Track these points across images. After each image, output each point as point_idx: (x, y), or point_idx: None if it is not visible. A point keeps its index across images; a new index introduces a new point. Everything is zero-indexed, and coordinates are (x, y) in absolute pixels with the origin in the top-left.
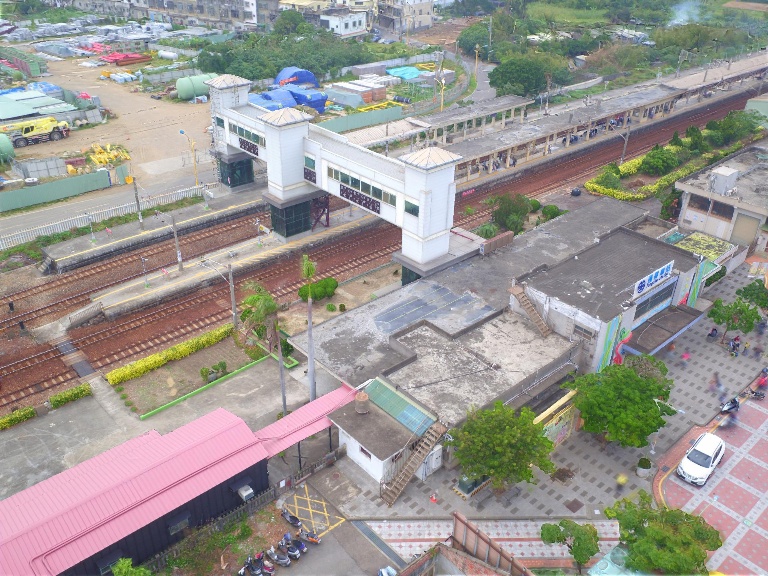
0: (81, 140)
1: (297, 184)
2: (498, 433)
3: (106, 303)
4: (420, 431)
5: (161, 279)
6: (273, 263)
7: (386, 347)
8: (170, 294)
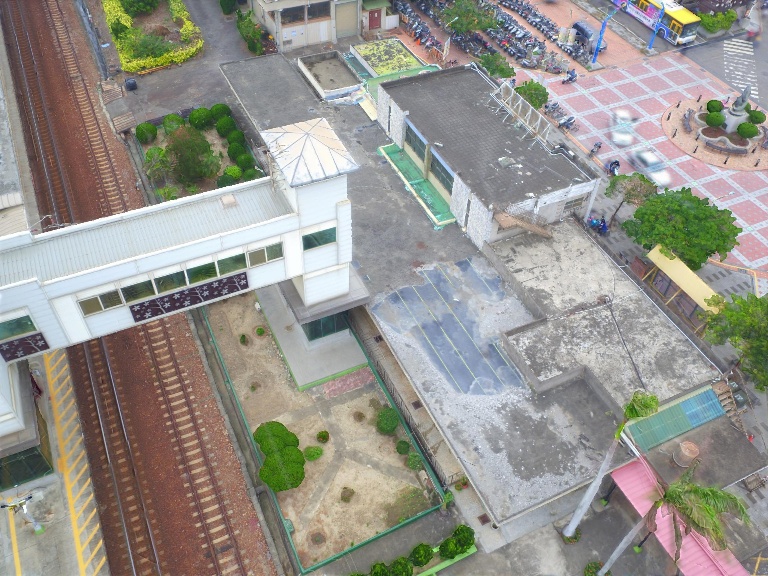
0: None
1: (9, 383)
2: None
3: None
4: (719, 409)
5: None
6: (100, 520)
7: (539, 397)
8: None
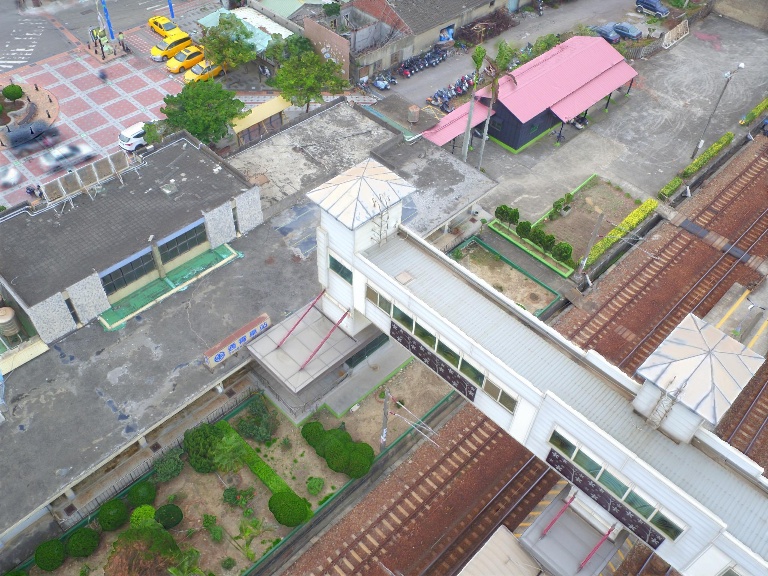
0: None
1: None
2: (315, 66)
3: (757, 302)
4: (367, 107)
5: None
6: None
7: None
8: None
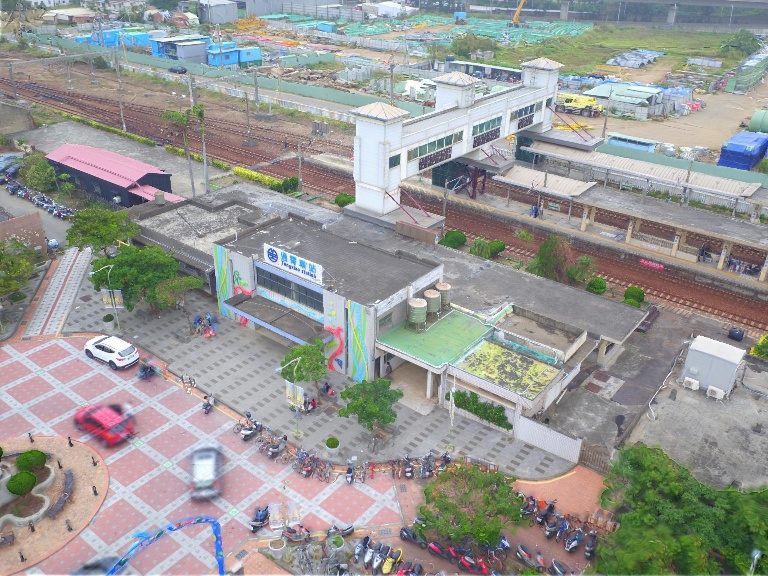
0: (594, 121)
1: None
2: None
3: (317, 157)
4: None
5: (352, 163)
6: None
7: None
8: (337, 170)
